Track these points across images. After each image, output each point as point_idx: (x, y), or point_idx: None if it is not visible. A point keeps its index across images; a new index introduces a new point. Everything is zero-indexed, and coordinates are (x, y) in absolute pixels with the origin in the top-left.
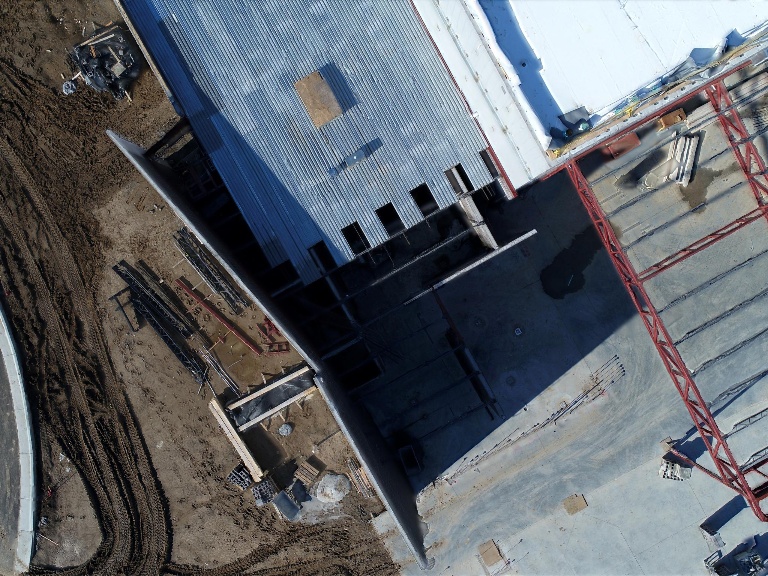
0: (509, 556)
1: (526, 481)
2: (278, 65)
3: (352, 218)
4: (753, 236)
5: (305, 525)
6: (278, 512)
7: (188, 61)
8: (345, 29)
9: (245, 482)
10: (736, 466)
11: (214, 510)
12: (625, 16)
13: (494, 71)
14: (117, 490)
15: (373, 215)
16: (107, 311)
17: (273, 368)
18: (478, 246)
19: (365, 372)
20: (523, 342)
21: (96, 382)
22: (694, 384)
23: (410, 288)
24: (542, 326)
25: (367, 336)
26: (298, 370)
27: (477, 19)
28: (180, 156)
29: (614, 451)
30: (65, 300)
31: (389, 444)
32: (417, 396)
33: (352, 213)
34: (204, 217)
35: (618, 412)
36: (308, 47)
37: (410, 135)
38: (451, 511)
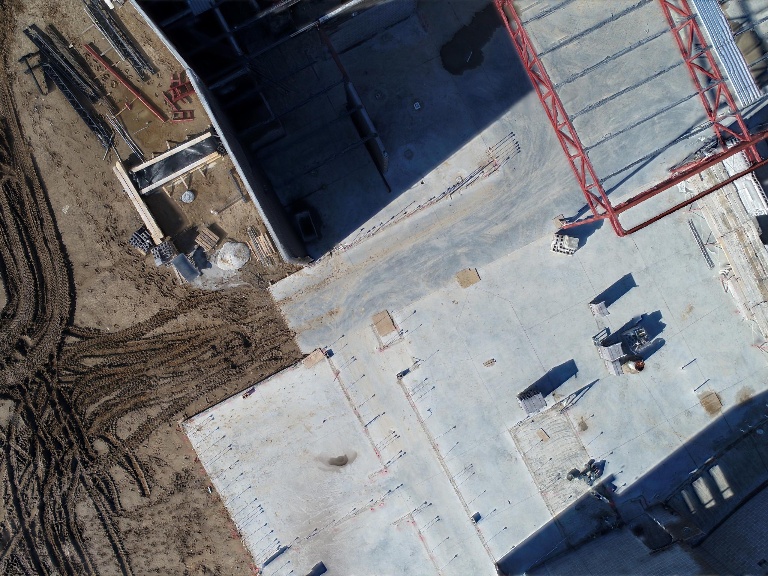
0: (402, 327)
1: (421, 253)
2: None
3: None
4: (649, 19)
5: (205, 292)
6: (178, 277)
7: None
8: None
9: (146, 244)
10: (597, 179)
11: (117, 275)
12: None
13: None
14: (23, 253)
15: None
16: (17, 75)
17: (178, 136)
18: None
19: (256, 114)
20: (422, 116)
21: (5, 145)
22: (558, 97)
23: None
24: (441, 101)
25: (254, 67)
26: (201, 135)
27: None
28: None
29: (508, 227)
30: None
31: (288, 212)
32: None
33: None
34: None
35: (512, 188)
36: None
37: None
38: (347, 281)
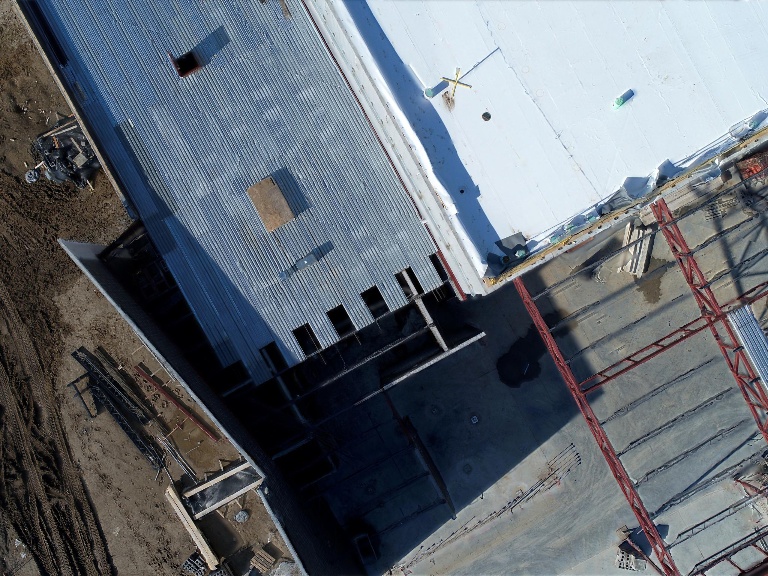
0: None
1: (483, 570)
2: (231, 169)
3: (303, 319)
4: None
5: None
6: None
7: (143, 164)
8: (298, 135)
9: (201, 570)
10: None
11: None
12: (560, 145)
13: (432, 199)
14: None
15: (324, 317)
16: (65, 397)
17: (231, 455)
18: (433, 338)
19: (317, 468)
20: (479, 430)
21: (53, 468)
22: (637, 495)
23: (367, 376)
24: (498, 414)
25: (318, 436)
26: None
27: (415, 150)
28: (140, 244)
29: (570, 540)
30: (24, 385)
31: (346, 532)
32: (374, 484)
33: (303, 314)
34: (157, 316)
35: (574, 501)
36: (261, 152)
37: (361, 239)
38: None
